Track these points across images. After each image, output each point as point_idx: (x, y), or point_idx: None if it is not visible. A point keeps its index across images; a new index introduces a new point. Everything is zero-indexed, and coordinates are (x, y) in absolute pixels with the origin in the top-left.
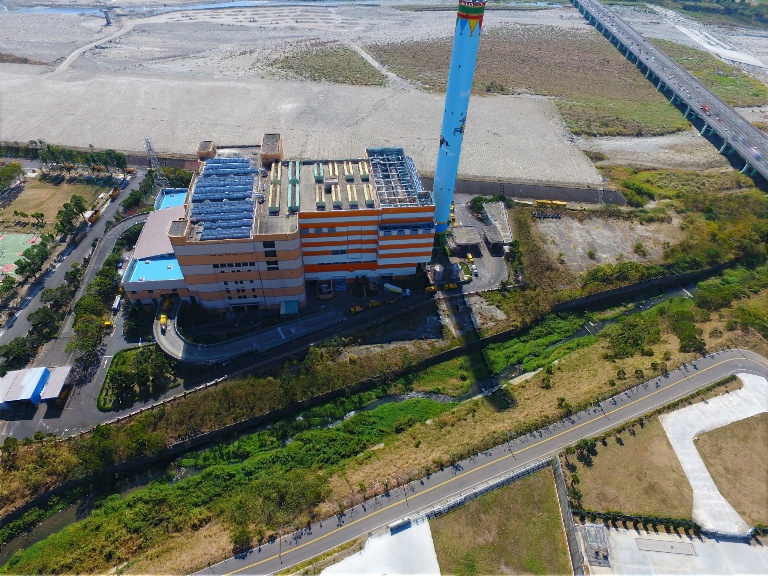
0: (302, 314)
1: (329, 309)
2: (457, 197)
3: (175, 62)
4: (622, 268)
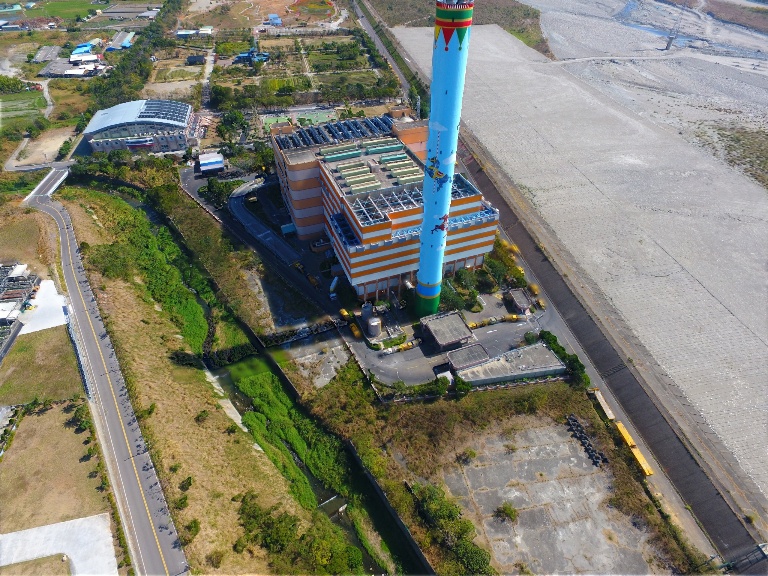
0: (289, 240)
1: (298, 253)
2: (555, 323)
3: (637, 90)
4: (468, 551)
